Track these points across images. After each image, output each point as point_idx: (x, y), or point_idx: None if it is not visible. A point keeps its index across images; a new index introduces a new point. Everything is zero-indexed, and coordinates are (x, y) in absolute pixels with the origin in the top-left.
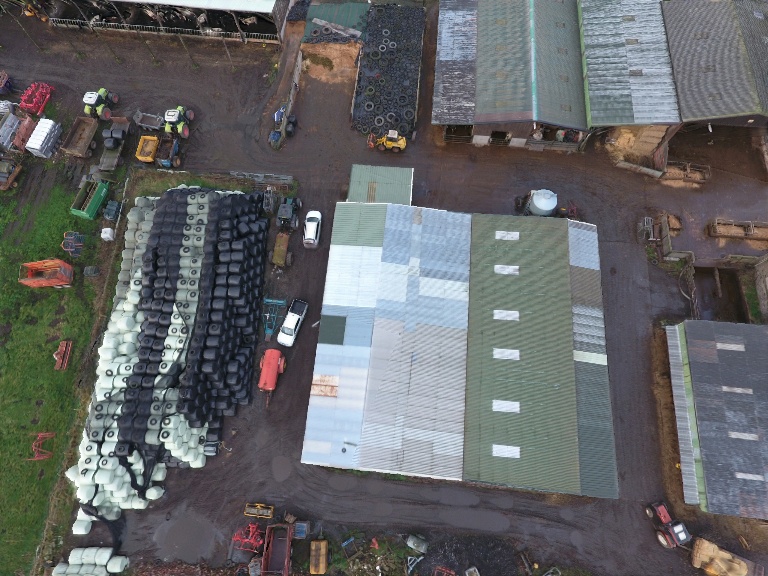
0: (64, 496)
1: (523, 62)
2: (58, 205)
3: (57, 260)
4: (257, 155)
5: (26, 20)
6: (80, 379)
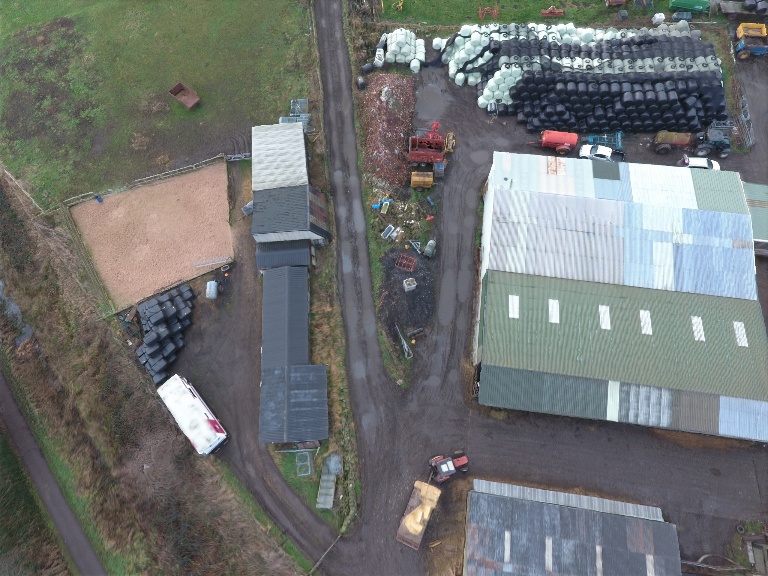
0: None
1: None
2: None
3: None
4: None
5: None
6: None
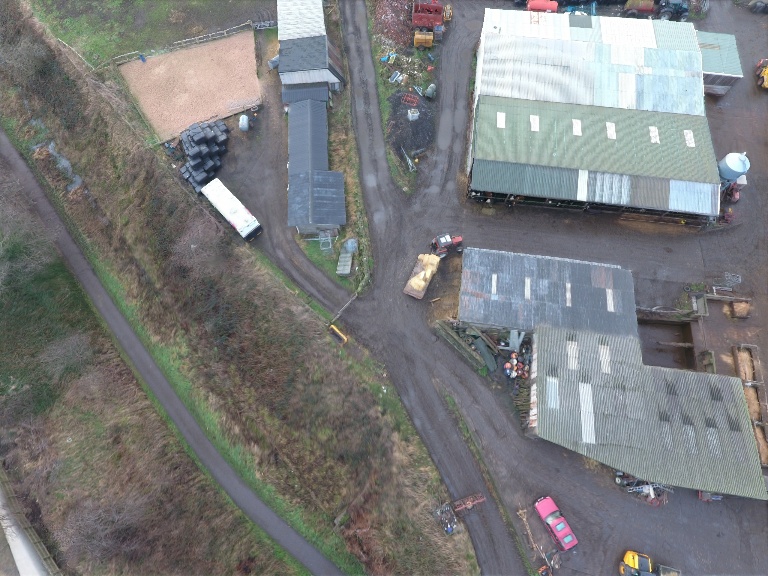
0: None
1: None
2: None
3: None
4: None
5: None
6: None
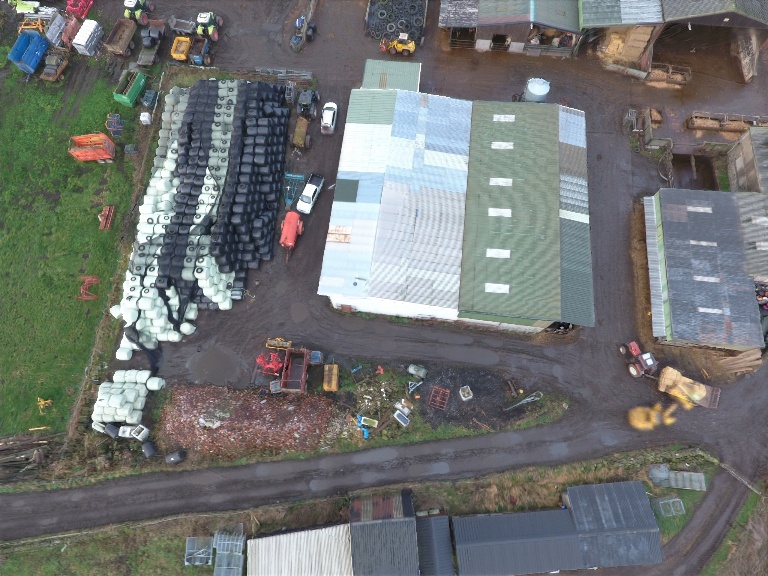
0: (108, 330)
1: None
2: (101, 95)
3: (102, 134)
4: (280, 56)
5: None
6: (122, 237)
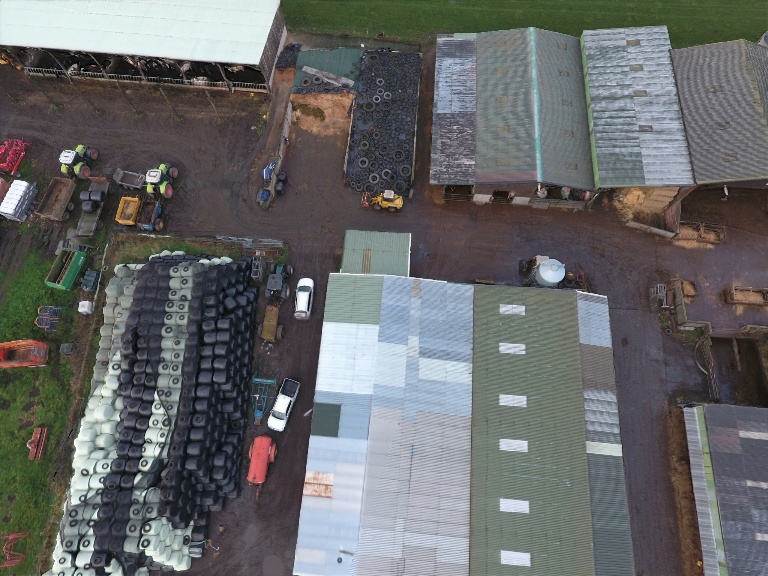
0: None
1: (526, 116)
2: (33, 274)
3: (30, 340)
4: (245, 216)
5: (0, 68)
6: (55, 471)
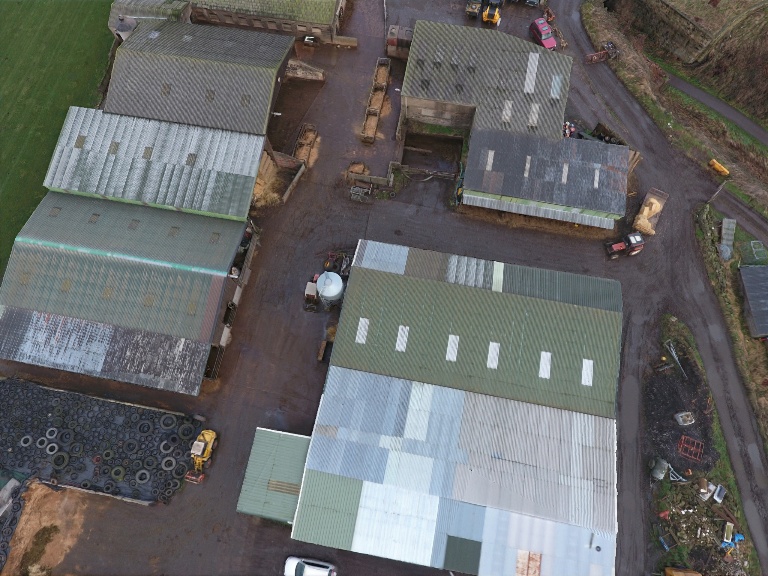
0: None
1: (139, 272)
2: None
3: None
4: None
5: None
6: None
